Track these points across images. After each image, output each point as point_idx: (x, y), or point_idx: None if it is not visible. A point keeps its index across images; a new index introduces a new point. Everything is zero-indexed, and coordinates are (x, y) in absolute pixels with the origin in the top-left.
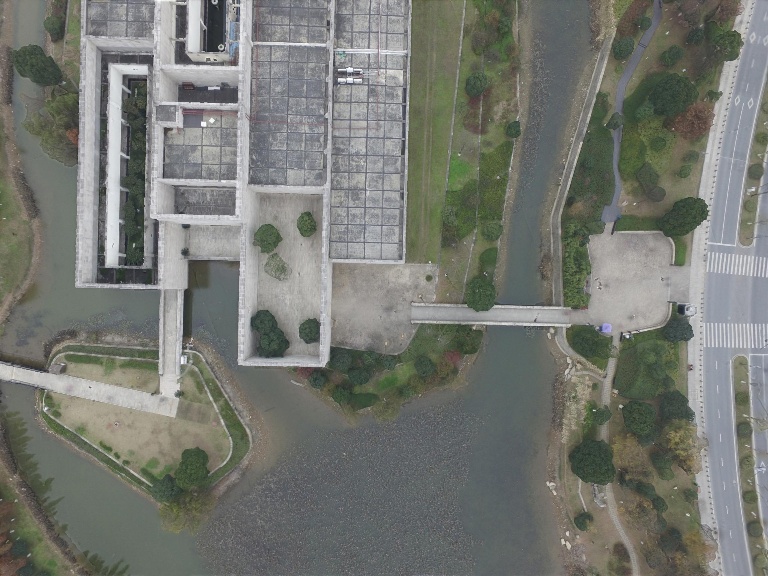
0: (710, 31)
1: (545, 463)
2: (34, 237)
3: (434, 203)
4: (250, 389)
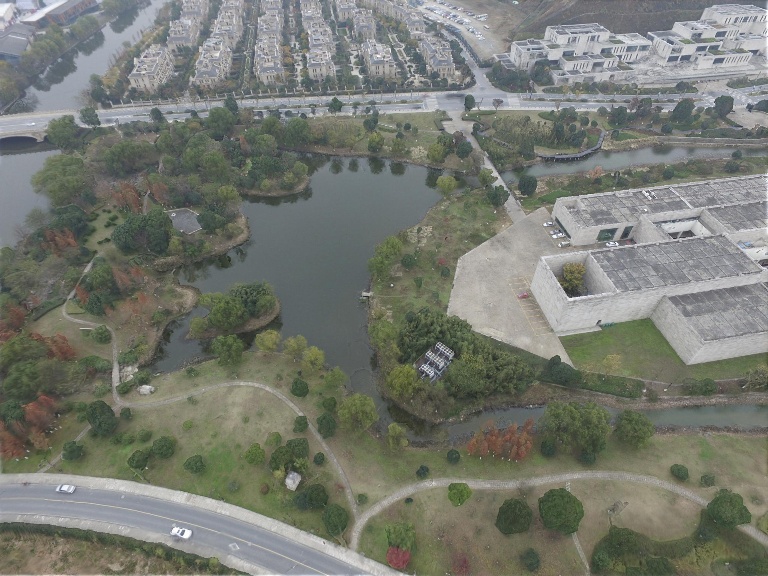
0: None
1: None
2: None
3: None
4: None
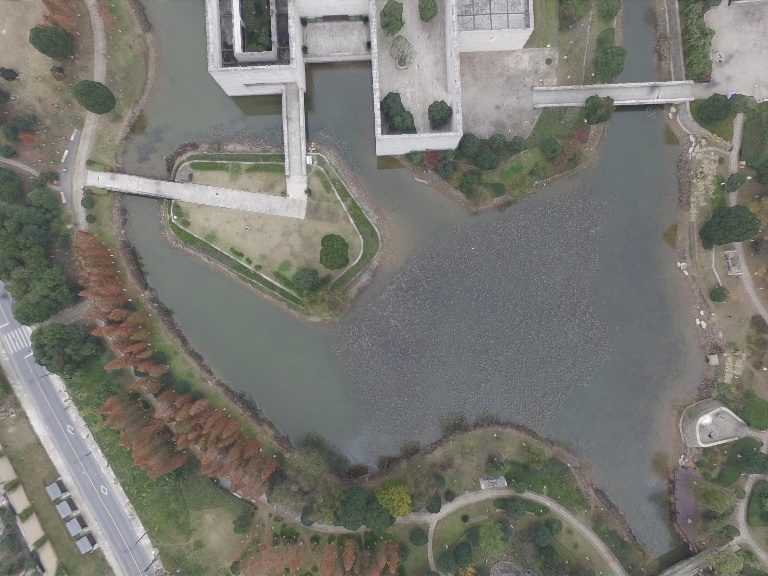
0: None
1: (674, 244)
2: (149, 51)
3: None
4: (374, 190)
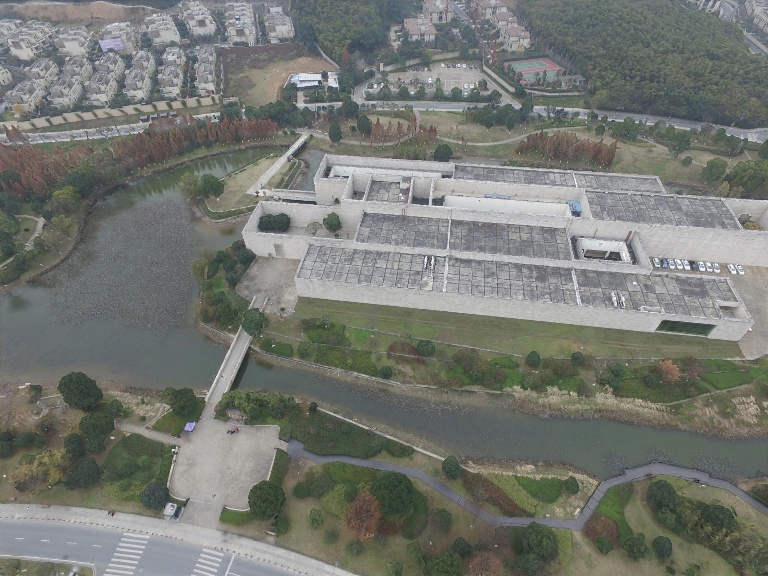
0: None
1: (101, 378)
2: None
3: (338, 318)
4: None
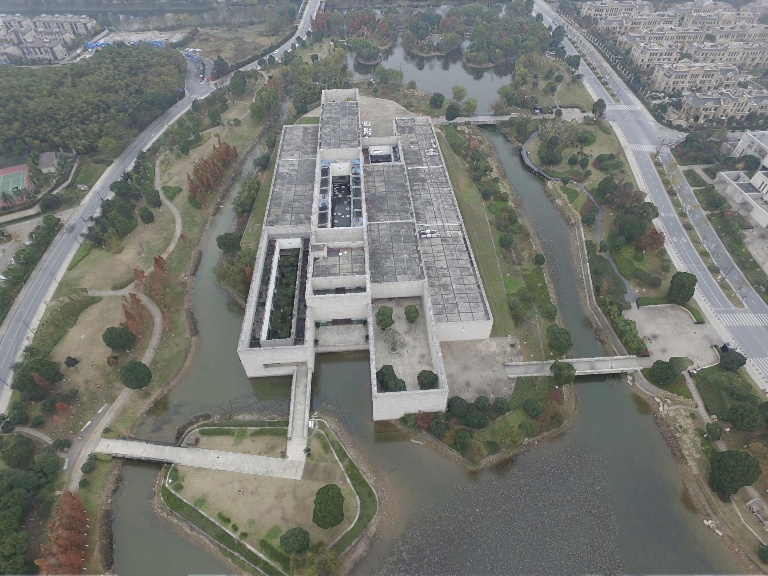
0: (636, 212)
1: (690, 500)
2: (191, 348)
3: (500, 301)
4: (372, 452)
